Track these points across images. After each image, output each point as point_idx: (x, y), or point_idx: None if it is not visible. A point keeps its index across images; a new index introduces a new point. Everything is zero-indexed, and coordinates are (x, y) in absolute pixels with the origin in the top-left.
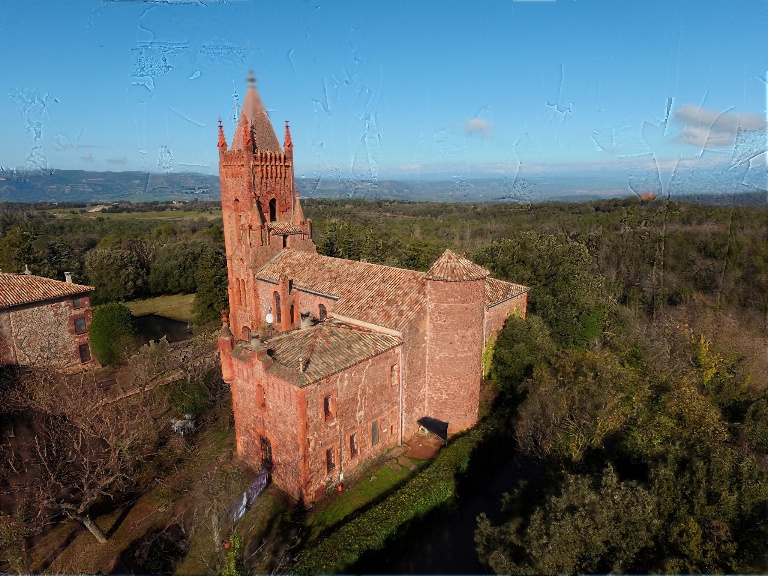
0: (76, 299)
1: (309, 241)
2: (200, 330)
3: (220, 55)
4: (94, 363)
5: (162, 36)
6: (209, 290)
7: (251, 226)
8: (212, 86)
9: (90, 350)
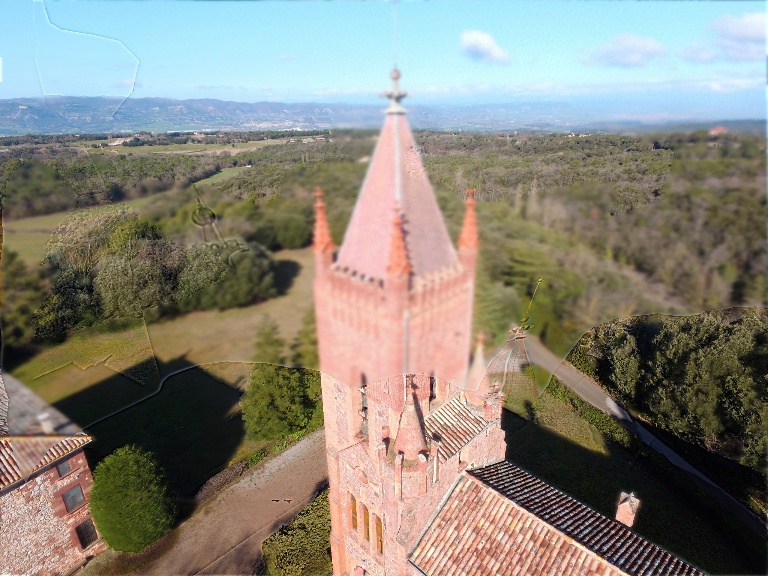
0: (62, 462)
1: (496, 430)
2: (257, 439)
3: (518, 188)
4: (103, 540)
5: (181, 66)
6: (268, 380)
7: (401, 452)
8: (430, 306)
9: (95, 525)
